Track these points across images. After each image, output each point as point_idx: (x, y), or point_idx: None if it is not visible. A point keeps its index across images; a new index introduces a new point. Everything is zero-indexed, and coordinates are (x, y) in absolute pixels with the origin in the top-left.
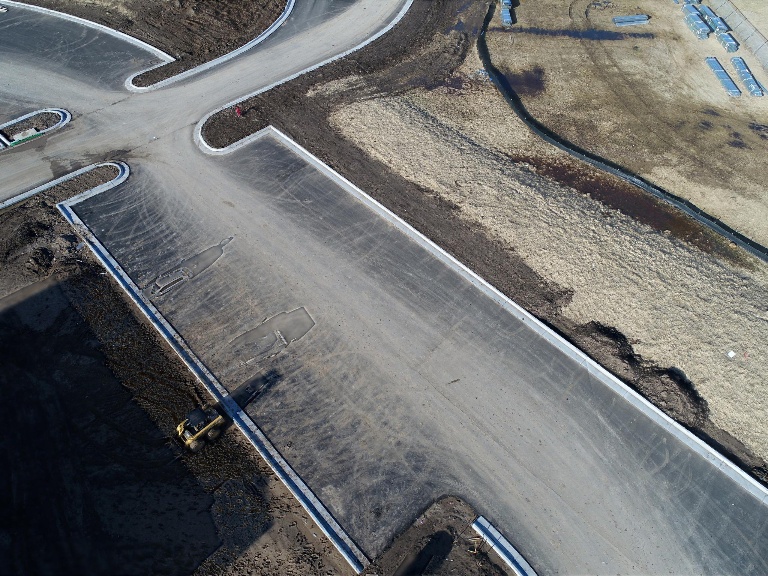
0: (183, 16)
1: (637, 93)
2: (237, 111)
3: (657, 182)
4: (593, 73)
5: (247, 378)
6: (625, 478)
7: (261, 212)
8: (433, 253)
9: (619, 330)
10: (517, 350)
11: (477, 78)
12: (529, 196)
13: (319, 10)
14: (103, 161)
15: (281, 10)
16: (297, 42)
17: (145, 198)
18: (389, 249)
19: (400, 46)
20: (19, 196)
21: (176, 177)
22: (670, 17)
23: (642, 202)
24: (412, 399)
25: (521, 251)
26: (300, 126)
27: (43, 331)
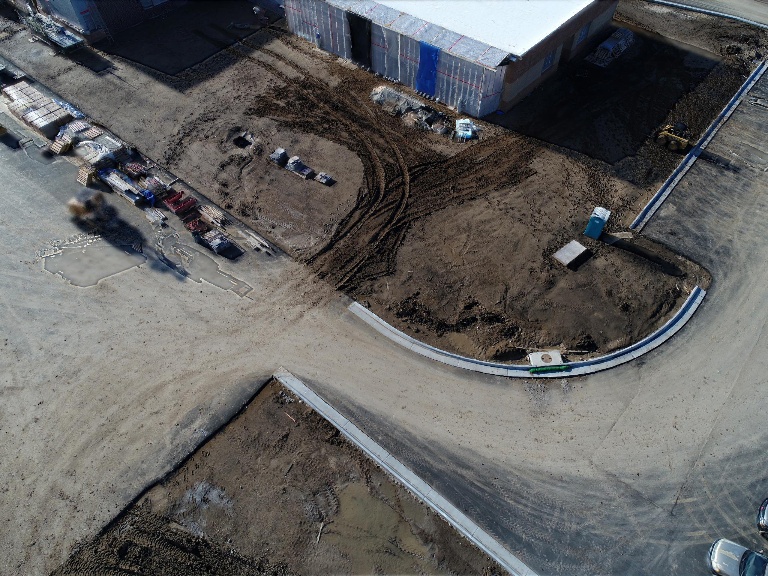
0: None
1: None
2: None
3: None
4: None
5: (722, 155)
6: None
7: None
8: None
9: None
10: None
11: None
12: None
13: None
14: None
15: None
16: None
17: None
18: None
19: None
20: None
21: None
22: None
23: None
24: None
25: None
26: None
27: (685, 66)
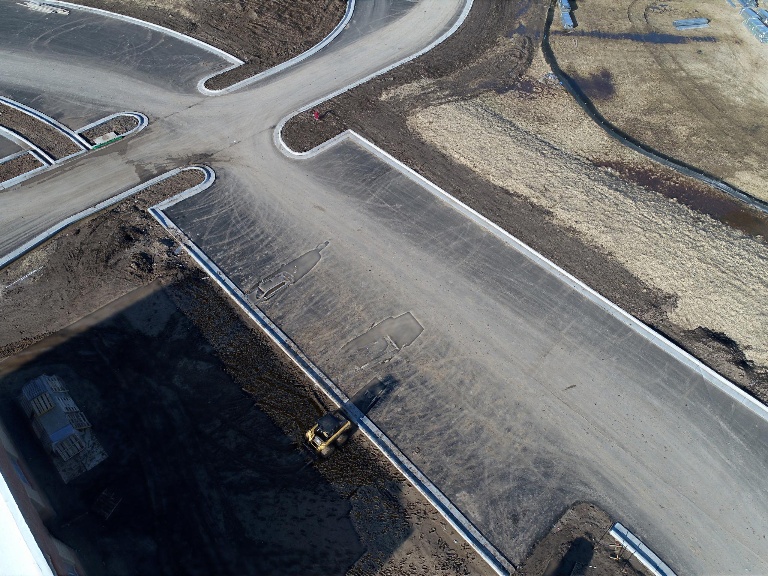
0: (246, 19)
1: (708, 97)
2: (315, 115)
3: (742, 187)
4: (661, 77)
5: (365, 383)
6: (755, 484)
7: (353, 216)
8: (531, 258)
9: (728, 336)
10: (629, 356)
11: (547, 82)
12: (619, 201)
13: (380, 13)
14: (187, 165)
15: (342, 13)
16: (363, 45)
17: (235, 202)
18: (486, 254)
19: (466, 49)
20: (109, 200)
21: (262, 181)
22: (729, 21)
23: (729, 207)
24: (531, 405)
25: (620, 256)
26: (379, 130)
27: (155, 336)
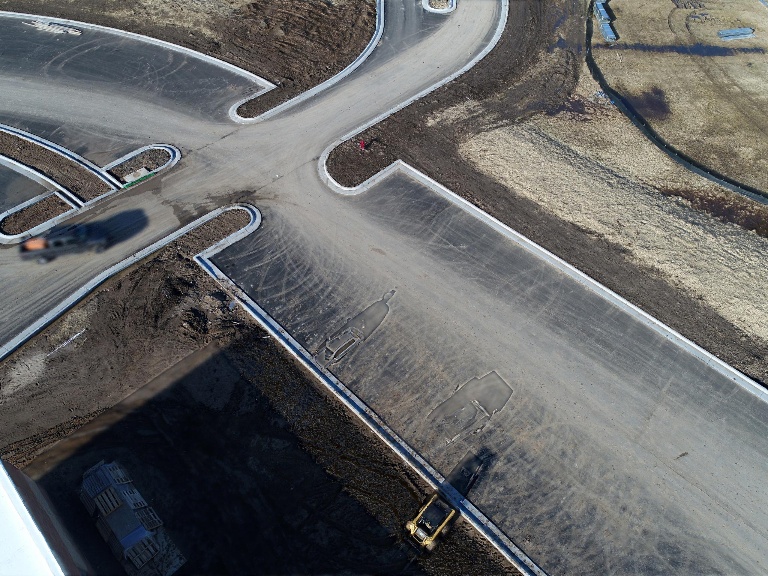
0: (271, 37)
1: (767, 115)
2: (361, 144)
3: None
4: (715, 93)
5: (459, 459)
6: None
7: (417, 260)
8: (616, 304)
9: None
10: (739, 416)
11: (598, 101)
12: (699, 236)
13: (412, 28)
14: (229, 204)
15: (372, 28)
16: (399, 64)
17: (286, 246)
18: (567, 300)
19: (508, 67)
20: (149, 247)
21: (313, 221)
22: None
23: None
24: (644, 478)
25: (711, 300)
26: (431, 160)
27: (221, 410)
